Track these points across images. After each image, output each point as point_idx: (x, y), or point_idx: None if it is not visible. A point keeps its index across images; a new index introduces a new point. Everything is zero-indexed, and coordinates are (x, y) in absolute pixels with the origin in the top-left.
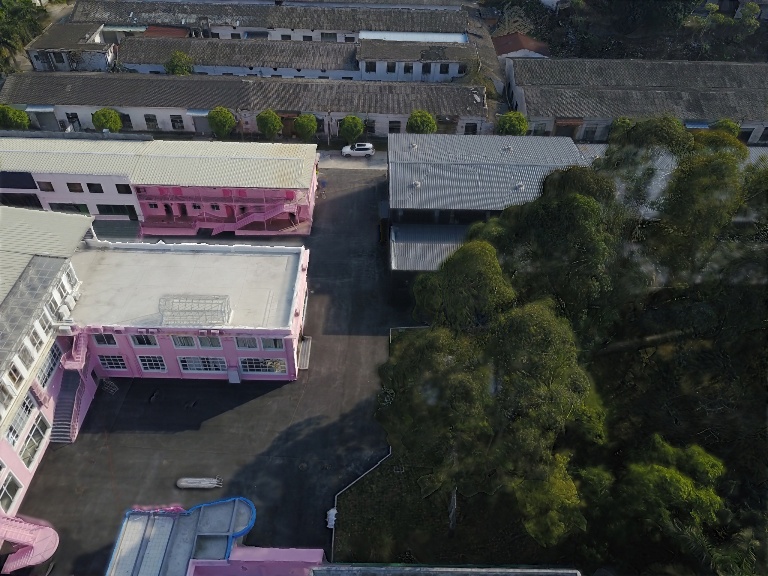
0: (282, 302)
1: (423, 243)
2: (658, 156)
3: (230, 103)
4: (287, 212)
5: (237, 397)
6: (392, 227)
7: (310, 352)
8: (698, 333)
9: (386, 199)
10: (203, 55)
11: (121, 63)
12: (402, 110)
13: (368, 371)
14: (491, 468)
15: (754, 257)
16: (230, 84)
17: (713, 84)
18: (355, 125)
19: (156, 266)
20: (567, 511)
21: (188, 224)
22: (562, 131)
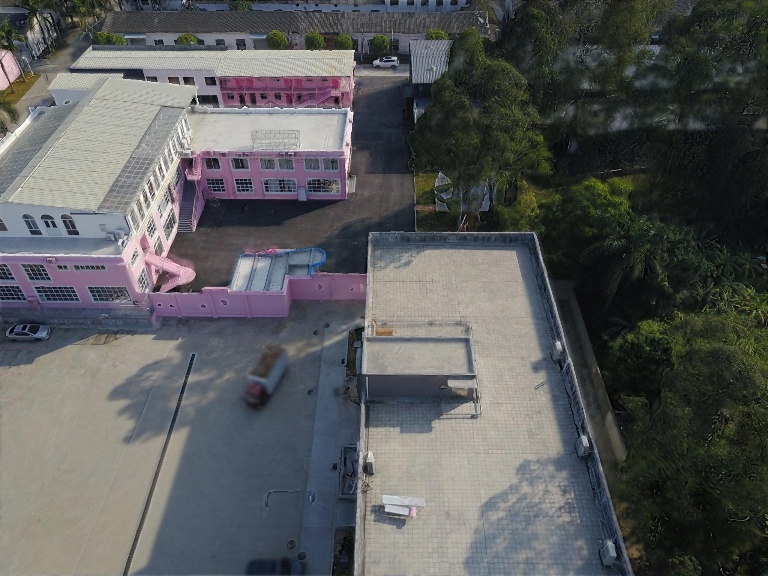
0: (336, 139)
1: None
2: None
3: (283, 28)
4: (334, 97)
5: (305, 208)
6: (414, 100)
7: (355, 183)
8: (621, 115)
9: None
10: None
11: (194, 3)
12: (420, 30)
13: (398, 193)
14: None
15: None
16: (282, 14)
17: None
18: (383, 41)
19: (243, 122)
20: (532, 222)
21: None
22: None
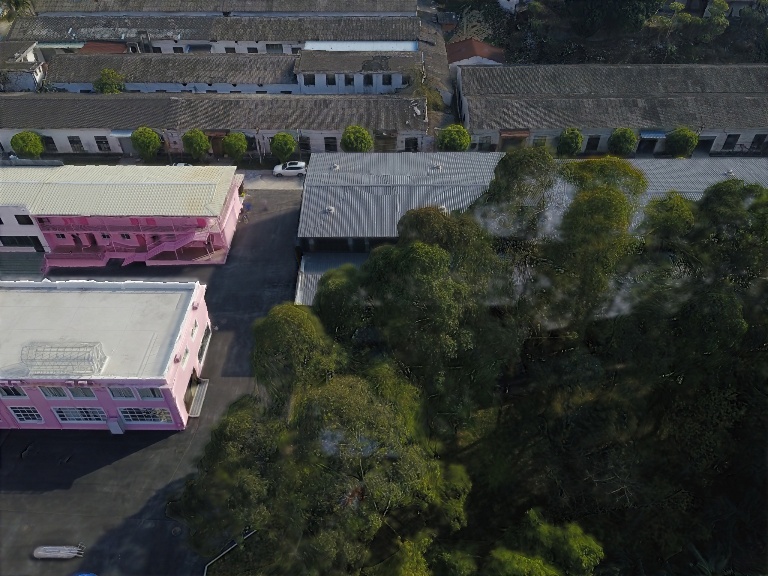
0: (164, 346)
1: None
2: (526, 192)
3: (156, 122)
4: (197, 241)
5: (118, 450)
6: (303, 257)
7: (204, 397)
8: (585, 391)
9: None
10: (135, 72)
11: (49, 82)
12: (337, 126)
13: None
14: None
15: (655, 300)
16: (157, 102)
17: (675, 89)
18: (285, 143)
19: (37, 307)
20: None
21: (95, 255)
22: (509, 144)
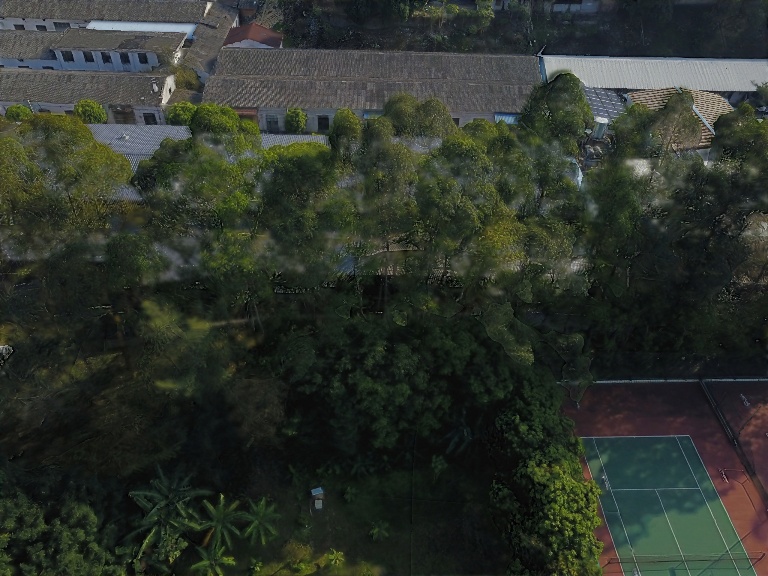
0: None
1: None
2: None
3: None
4: None
5: None
6: None
7: None
8: None
9: None
10: None
11: None
12: (74, 99)
13: None
14: None
15: (109, 243)
16: None
17: (418, 75)
18: (17, 114)
19: None
20: None
21: None
22: None
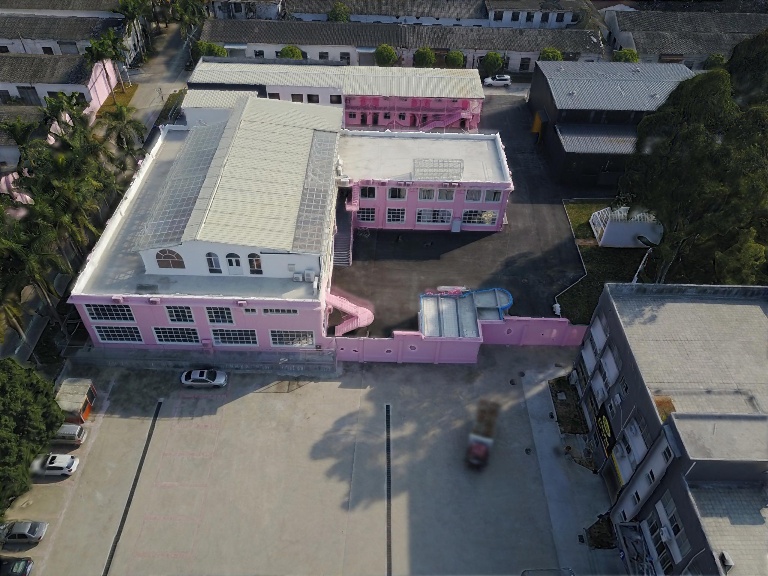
0: (495, 169)
1: (583, 136)
2: None
3: (391, 42)
4: (464, 119)
5: (460, 241)
6: (556, 126)
7: (506, 214)
8: None
9: (531, 115)
10: (357, 6)
11: (290, 12)
12: (533, 48)
13: (554, 226)
14: (719, 223)
15: None
16: (388, 27)
17: None
18: (497, 59)
19: (389, 146)
20: (754, 271)
21: (383, 129)
22: None
